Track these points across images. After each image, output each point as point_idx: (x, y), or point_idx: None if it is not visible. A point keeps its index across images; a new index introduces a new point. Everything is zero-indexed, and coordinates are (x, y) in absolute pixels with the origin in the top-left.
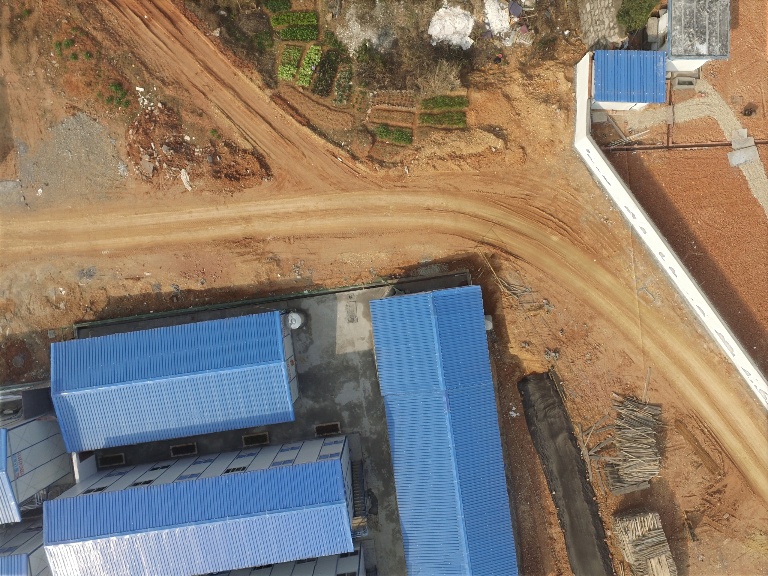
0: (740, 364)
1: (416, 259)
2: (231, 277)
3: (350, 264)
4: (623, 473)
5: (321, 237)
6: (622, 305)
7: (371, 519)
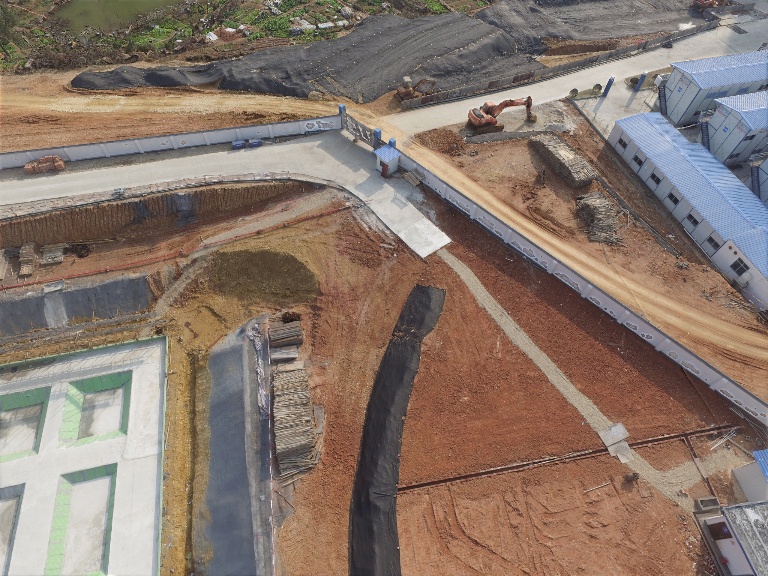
0: None
1: None
2: None
3: None
4: None
5: None
6: (651, 302)
7: None
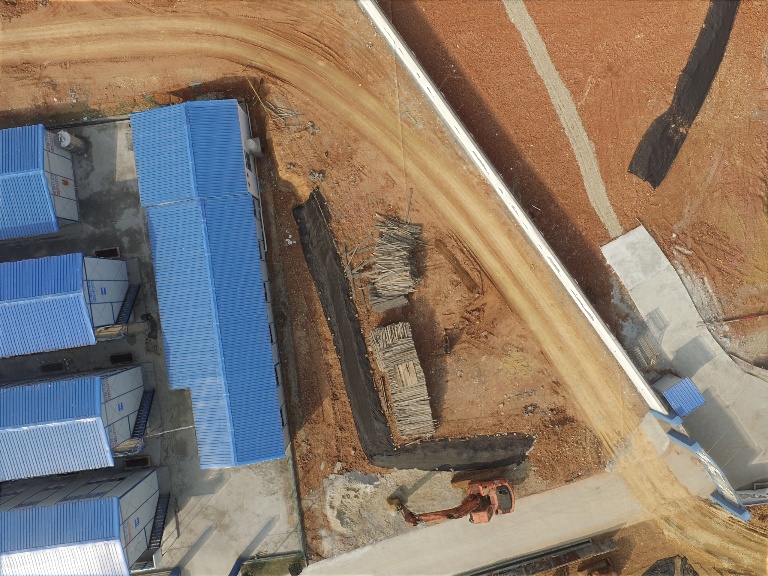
0: (494, 182)
1: (186, 82)
2: (9, 101)
3: (124, 88)
4: (379, 287)
5: (96, 62)
6: (385, 128)
7: (150, 343)
